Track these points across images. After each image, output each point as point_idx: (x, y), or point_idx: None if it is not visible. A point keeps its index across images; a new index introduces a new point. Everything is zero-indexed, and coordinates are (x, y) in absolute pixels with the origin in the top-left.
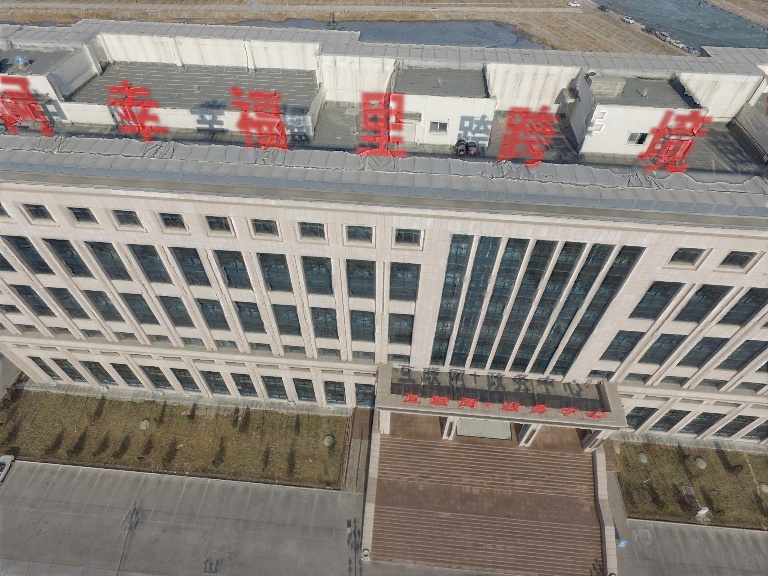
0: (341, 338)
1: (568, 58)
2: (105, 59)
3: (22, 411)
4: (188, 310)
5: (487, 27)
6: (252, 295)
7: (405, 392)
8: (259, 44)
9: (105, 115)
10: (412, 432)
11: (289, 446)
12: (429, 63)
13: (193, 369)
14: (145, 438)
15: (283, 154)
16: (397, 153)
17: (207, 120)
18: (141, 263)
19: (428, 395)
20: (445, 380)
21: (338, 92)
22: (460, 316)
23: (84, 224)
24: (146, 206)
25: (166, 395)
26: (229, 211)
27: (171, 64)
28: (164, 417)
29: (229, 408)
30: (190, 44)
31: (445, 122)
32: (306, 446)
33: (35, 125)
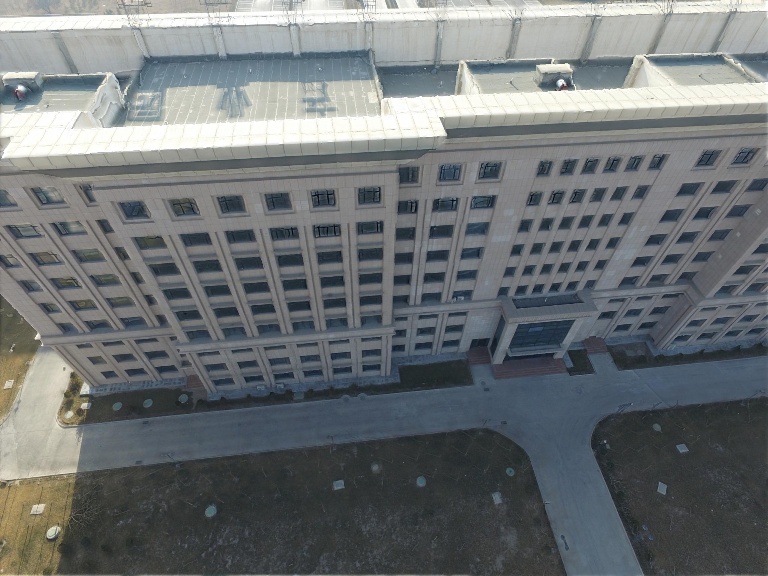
0: None
1: (604, 98)
2: None
3: None
4: None
5: None
6: None
7: None
8: None
9: None
10: None
11: None
12: None
13: None
14: None
15: (721, 6)
16: None
17: None
18: None
19: None
20: None
21: None
22: None
23: None
24: None
25: None
26: None
27: None
28: None
29: None
30: None
31: None
32: None
33: None
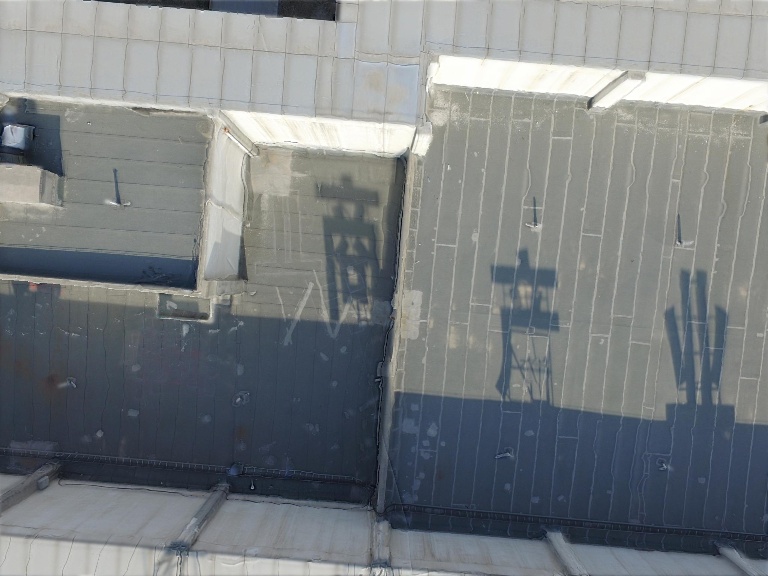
0: None
1: None
2: None
3: None
4: None
5: None
6: None
7: None
8: None
9: None
10: None
11: None
12: None
13: None
14: None
15: None
16: None
17: None
18: None
19: None
20: None
21: None
22: None
23: None
24: None
25: None
26: None
27: None
28: None
29: None
30: None
31: None
32: None
33: None
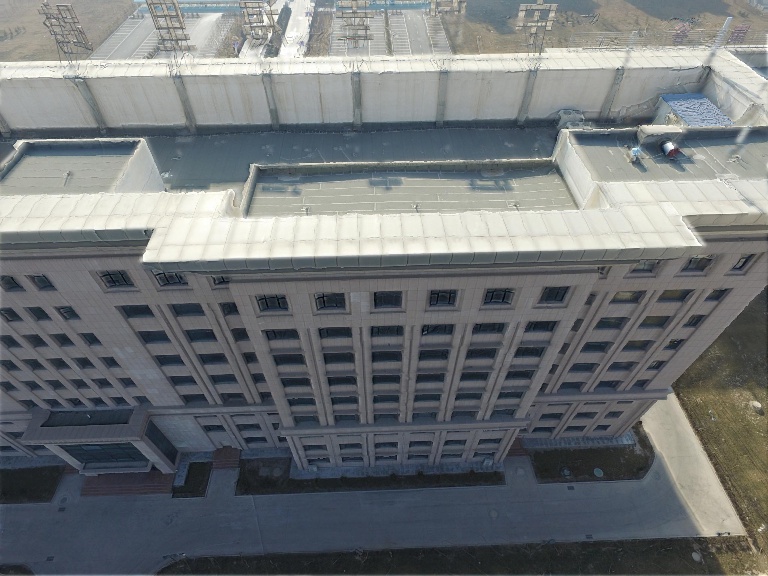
0: None
1: None
2: None
3: None
4: None
5: None
6: None
7: None
8: None
9: None
10: None
11: None
12: None
13: None
14: None
15: None
16: None
17: None
18: None
19: None
20: None
21: None
22: None
23: None
24: None
25: None
26: None
27: None
28: None
29: None
30: None
31: None
32: None
33: None
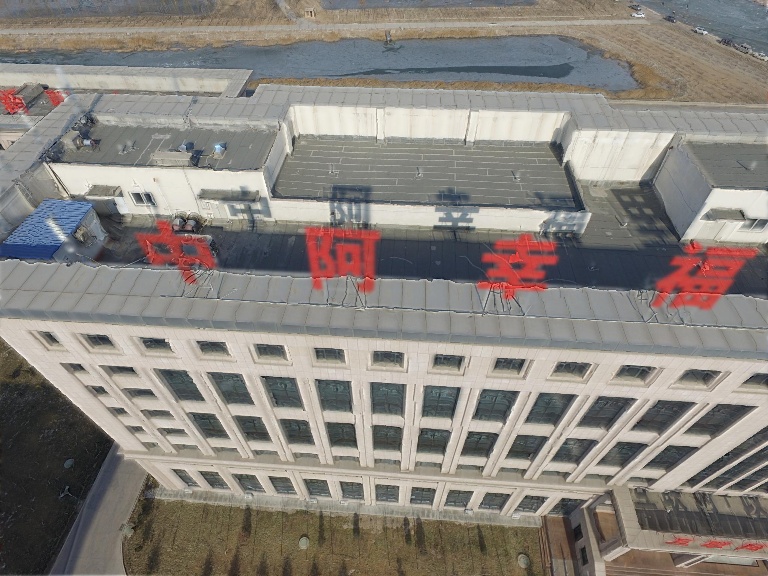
0: (583, 464)
1: None
2: (292, 134)
3: (158, 527)
4: (404, 438)
5: (552, 42)
6: (498, 427)
7: (650, 522)
8: (488, 114)
9: (322, 213)
10: (637, 558)
11: (479, 569)
12: (716, 138)
13: (369, 483)
14: (308, 561)
15: (672, 304)
16: (698, 256)
17: (452, 218)
18: (373, 397)
19: (678, 526)
20: (691, 503)
21: (583, 170)
22: (759, 449)
23: (324, 363)
24: (425, 349)
25: (321, 503)
26: (537, 355)
27: (368, 137)
28: (324, 532)
29: (397, 518)
30: (400, 115)
31: (767, 219)
32: (499, 569)
33: (230, 224)
